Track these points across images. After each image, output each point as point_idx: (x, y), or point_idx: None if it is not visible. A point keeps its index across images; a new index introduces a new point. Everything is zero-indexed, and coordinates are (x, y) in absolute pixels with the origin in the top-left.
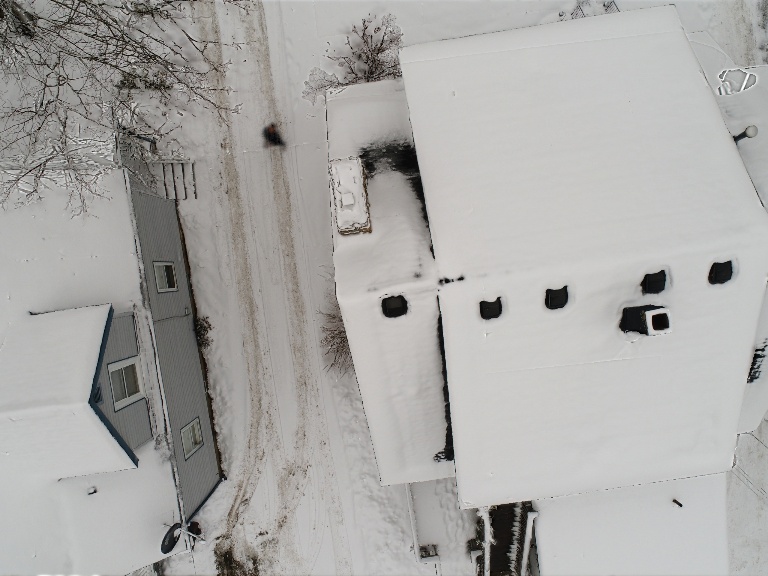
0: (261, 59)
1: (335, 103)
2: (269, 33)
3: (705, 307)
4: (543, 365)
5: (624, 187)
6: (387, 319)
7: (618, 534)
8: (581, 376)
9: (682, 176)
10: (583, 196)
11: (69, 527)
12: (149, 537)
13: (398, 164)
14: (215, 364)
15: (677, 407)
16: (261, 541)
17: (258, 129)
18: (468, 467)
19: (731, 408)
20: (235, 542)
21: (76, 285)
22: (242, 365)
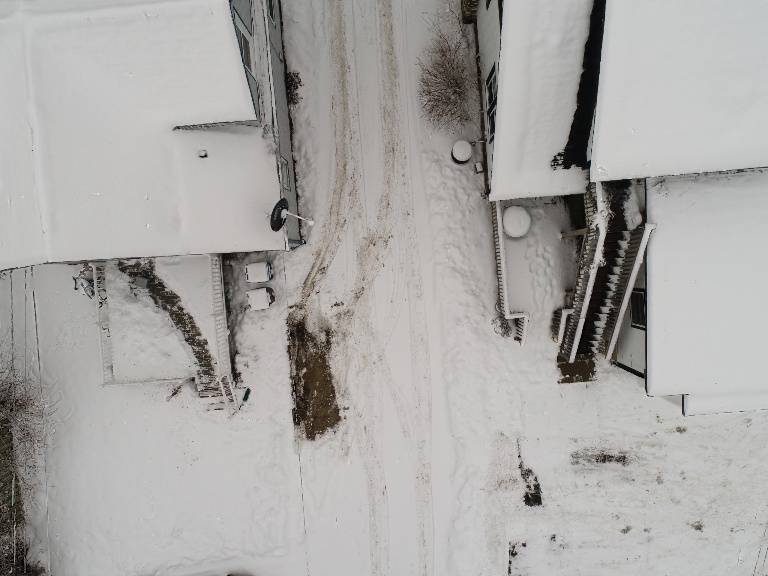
0: None
1: None
2: None
3: None
4: None
5: None
6: None
7: (733, 261)
8: (747, 3)
9: None
10: None
11: (180, 182)
12: (253, 221)
13: None
14: (302, 123)
15: None
16: (336, 312)
17: None
18: (611, 118)
19: None
20: (309, 312)
21: None
22: (329, 127)
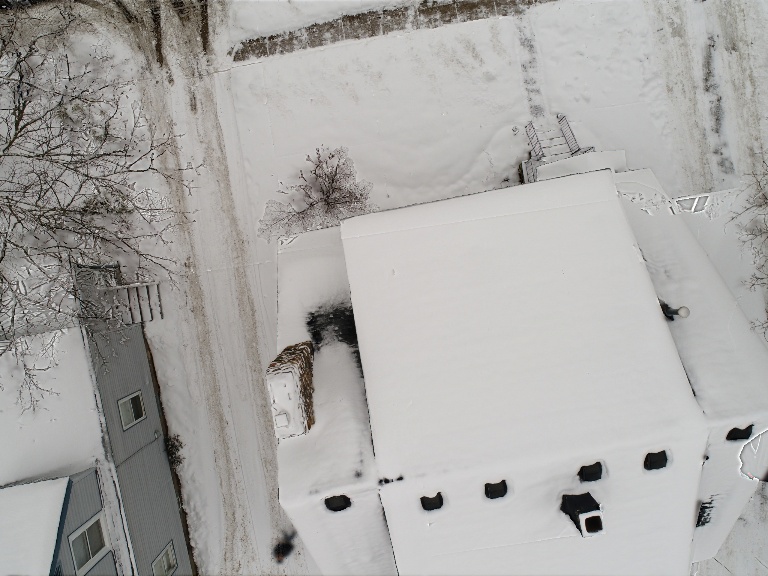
0: (221, 178)
1: (285, 258)
2: (228, 153)
3: (643, 490)
4: (488, 546)
5: (559, 376)
6: (332, 512)
7: None
8: (527, 553)
9: (615, 364)
10: (519, 386)
11: None
12: None
13: (344, 333)
14: (188, 480)
15: (624, 573)
16: None
17: (221, 248)
18: None
19: (678, 571)
20: None
21: (36, 451)
22: (215, 480)
